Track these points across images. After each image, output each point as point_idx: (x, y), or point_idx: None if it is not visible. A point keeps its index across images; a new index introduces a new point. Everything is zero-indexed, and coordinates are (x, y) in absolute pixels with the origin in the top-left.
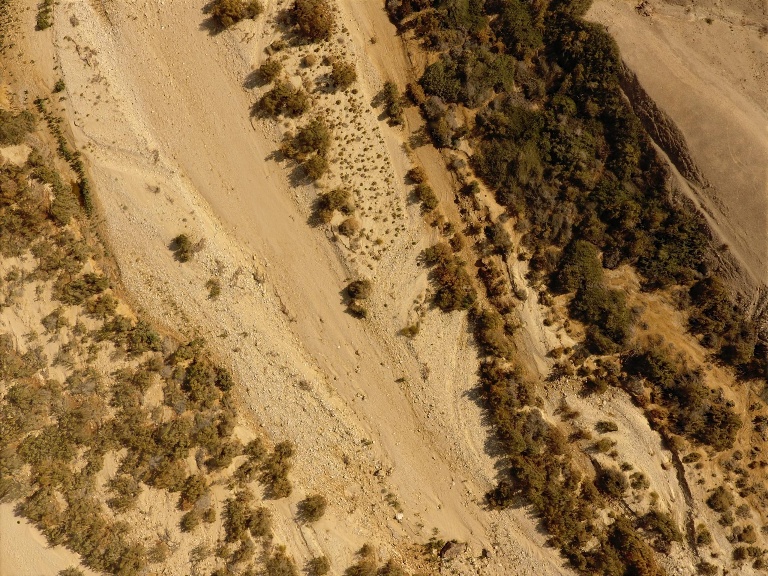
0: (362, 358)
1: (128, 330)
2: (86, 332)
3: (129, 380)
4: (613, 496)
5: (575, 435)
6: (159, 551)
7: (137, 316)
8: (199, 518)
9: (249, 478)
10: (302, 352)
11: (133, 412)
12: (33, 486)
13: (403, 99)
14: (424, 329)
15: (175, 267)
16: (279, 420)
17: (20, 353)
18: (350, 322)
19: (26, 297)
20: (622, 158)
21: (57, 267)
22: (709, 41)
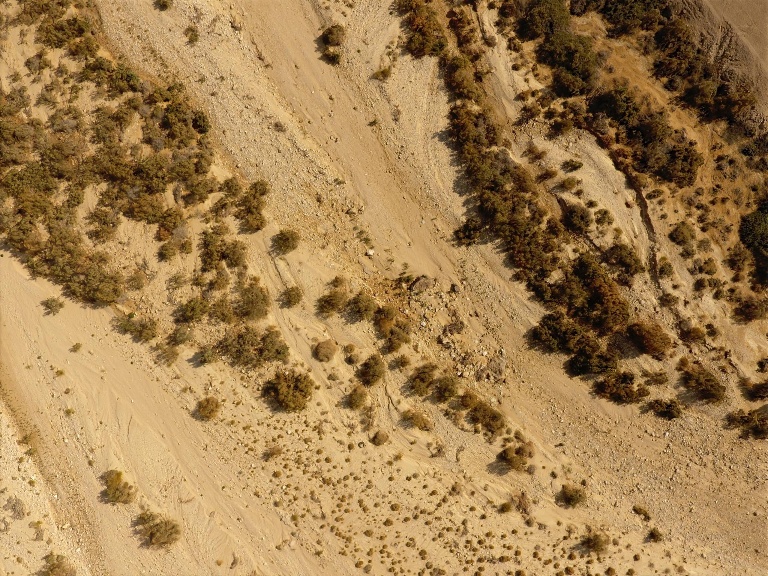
0: (336, 103)
1: (109, 72)
2: (68, 73)
3: (109, 118)
4: (578, 233)
5: (542, 176)
6: (137, 278)
7: (118, 62)
8: (176, 249)
9: (225, 212)
10: (277, 97)
11: (113, 146)
12: (16, 217)
13: None
14: (396, 73)
15: (155, 15)
16: (254, 161)
17: (4, 93)
18: (324, 69)
19: (10, 41)
20: None
21: (40, 12)
22: None
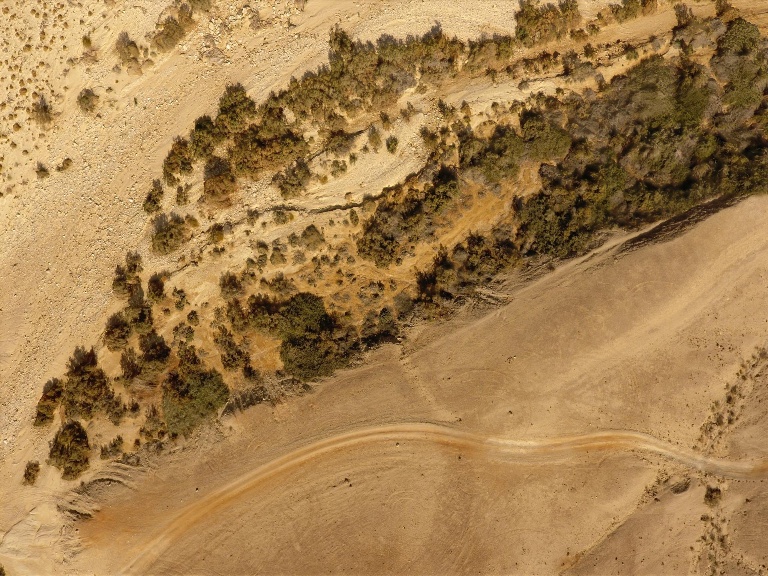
0: None
1: None
2: None
3: None
4: None
5: (387, 119)
6: None
7: None
8: None
9: None
10: None
11: None
12: None
13: (725, 4)
14: None
15: None
16: None
17: None
18: None
19: None
20: (648, 192)
21: None
22: (759, 293)
